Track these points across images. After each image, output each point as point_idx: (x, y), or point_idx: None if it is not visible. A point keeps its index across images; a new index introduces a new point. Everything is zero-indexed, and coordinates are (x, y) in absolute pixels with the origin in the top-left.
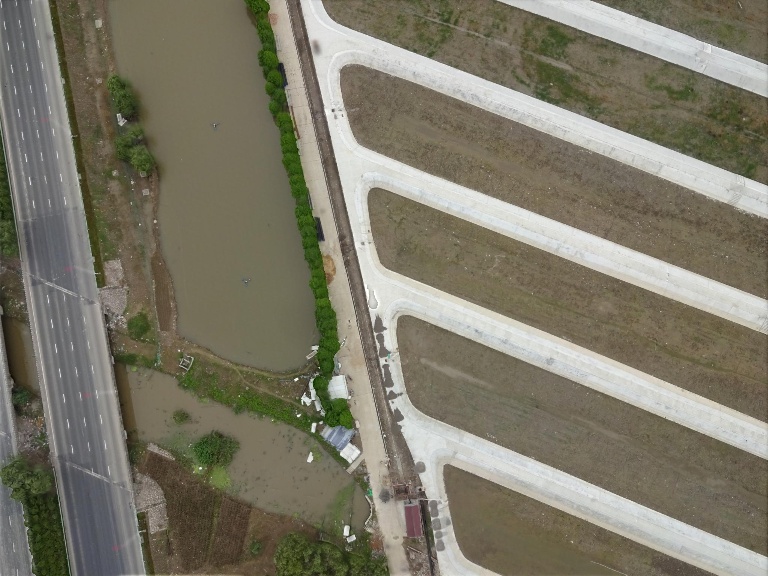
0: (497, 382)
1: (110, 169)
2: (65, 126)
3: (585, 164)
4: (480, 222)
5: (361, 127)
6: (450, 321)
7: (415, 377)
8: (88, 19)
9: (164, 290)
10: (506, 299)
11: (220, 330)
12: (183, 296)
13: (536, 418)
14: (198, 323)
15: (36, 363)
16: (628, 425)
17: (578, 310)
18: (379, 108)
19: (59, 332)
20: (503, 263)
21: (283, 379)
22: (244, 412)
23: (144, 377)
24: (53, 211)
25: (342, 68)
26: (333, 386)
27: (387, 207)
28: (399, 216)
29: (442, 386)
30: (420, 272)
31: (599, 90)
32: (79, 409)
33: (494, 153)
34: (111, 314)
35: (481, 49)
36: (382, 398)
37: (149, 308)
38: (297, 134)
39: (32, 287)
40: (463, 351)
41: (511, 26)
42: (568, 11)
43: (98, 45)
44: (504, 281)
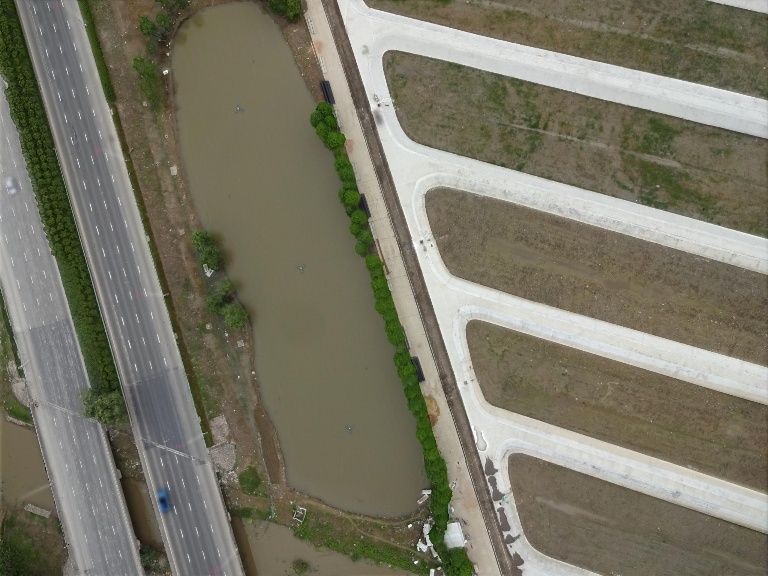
0: (619, 518)
1: (203, 323)
2: (155, 285)
3: (702, 274)
4: (589, 349)
5: (452, 255)
6: (564, 458)
7: (531, 517)
8: (163, 167)
9: (270, 442)
10: (623, 429)
11: (329, 480)
12: (289, 447)
13: (664, 554)
14: (307, 473)
15: (159, 526)
16: (766, 557)
17: (703, 436)
18: (469, 232)
19: (176, 494)
20: (617, 390)
21: (396, 526)
22: (361, 559)
23: (260, 529)
24: (155, 373)
25: (426, 192)
26: (449, 534)
27: (487, 339)
28: (501, 348)
29: (560, 525)
30: (528, 406)
31: (713, 187)
32: (204, 568)
33: (598, 270)
34: (222, 471)
35: (576, 154)
36: (499, 541)
37: (257, 461)
38: (386, 269)
39: (145, 451)
40: (580, 487)
41: (608, 124)
42: (673, 101)
43: (176, 194)
44: (619, 410)
